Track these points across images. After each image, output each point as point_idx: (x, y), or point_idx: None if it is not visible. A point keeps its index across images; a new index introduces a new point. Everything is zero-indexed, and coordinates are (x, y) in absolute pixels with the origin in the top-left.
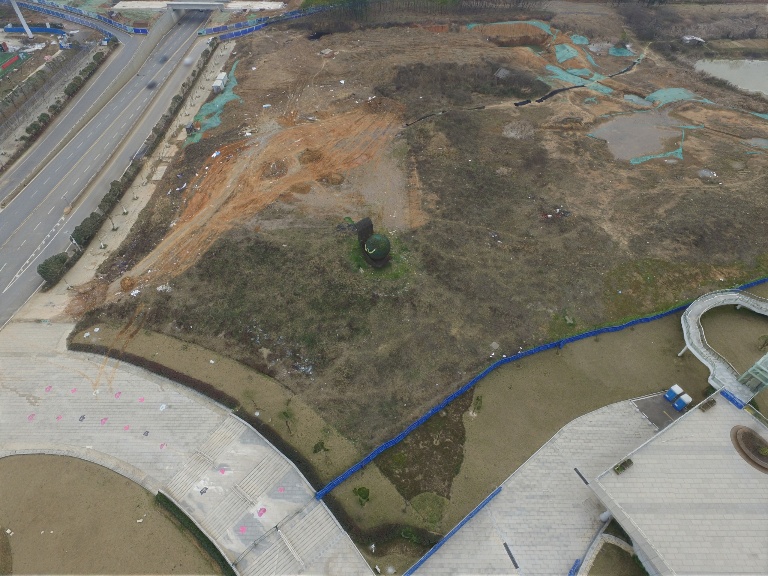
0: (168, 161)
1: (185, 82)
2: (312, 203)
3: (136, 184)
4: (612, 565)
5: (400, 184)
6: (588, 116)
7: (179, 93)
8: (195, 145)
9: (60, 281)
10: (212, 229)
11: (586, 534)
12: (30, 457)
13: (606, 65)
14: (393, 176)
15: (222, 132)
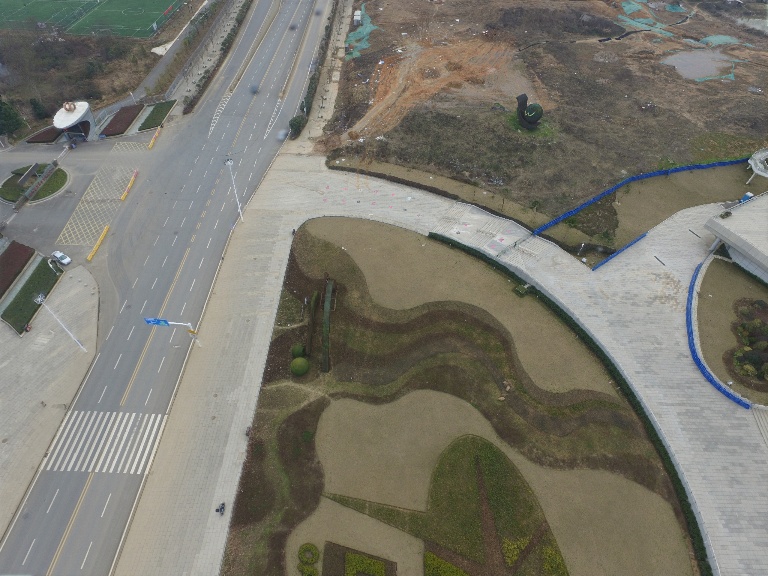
0: (338, 69)
1: (330, 16)
2: (467, 94)
3: (322, 82)
4: (721, 265)
5: (528, 86)
6: (658, 50)
7: (328, 24)
8: (362, 57)
9: (300, 134)
10: (401, 106)
11: (702, 255)
12: (336, 218)
13: (665, 17)
14: (521, 81)
15: (375, 51)
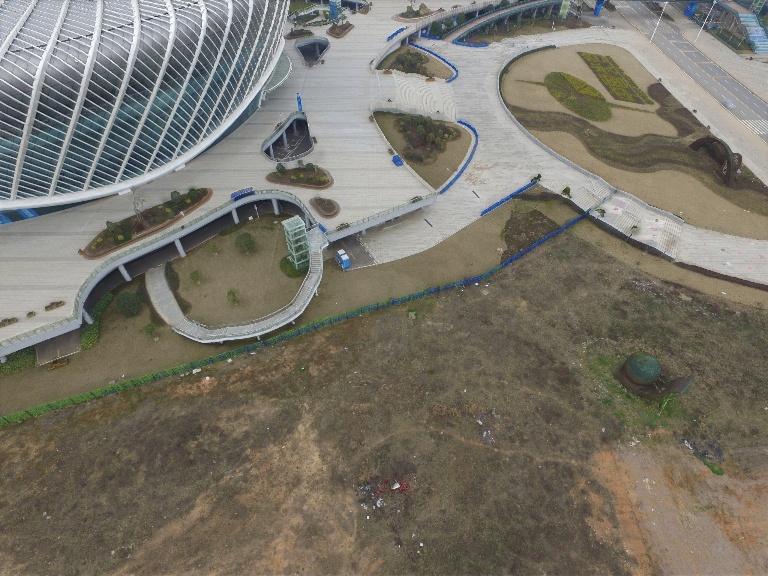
0: None
1: None
2: None
3: None
4: None
5: None
6: None
7: None
8: None
9: None
10: None
11: None
12: None
13: None
14: None
15: None
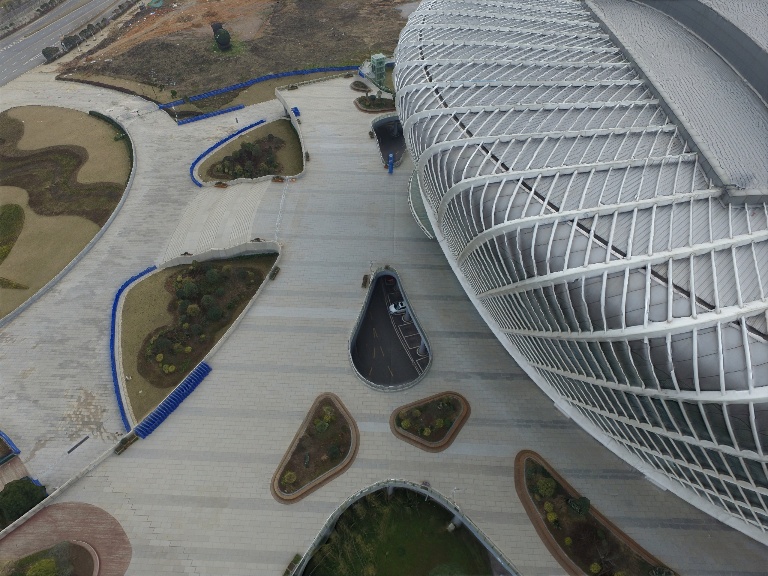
0: None
1: None
2: (201, 31)
3: (104, 30)
4: None
5: (257, 25)
6: None
7: None
8: None
9: (54, 61)
10: (140, 39)
11: None
12: (34, 106)
13: None
14: (255, 22)
15: None
